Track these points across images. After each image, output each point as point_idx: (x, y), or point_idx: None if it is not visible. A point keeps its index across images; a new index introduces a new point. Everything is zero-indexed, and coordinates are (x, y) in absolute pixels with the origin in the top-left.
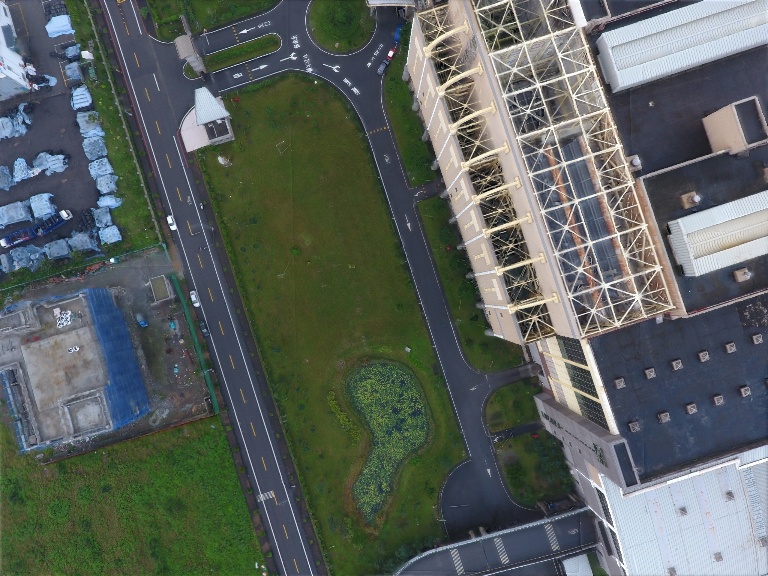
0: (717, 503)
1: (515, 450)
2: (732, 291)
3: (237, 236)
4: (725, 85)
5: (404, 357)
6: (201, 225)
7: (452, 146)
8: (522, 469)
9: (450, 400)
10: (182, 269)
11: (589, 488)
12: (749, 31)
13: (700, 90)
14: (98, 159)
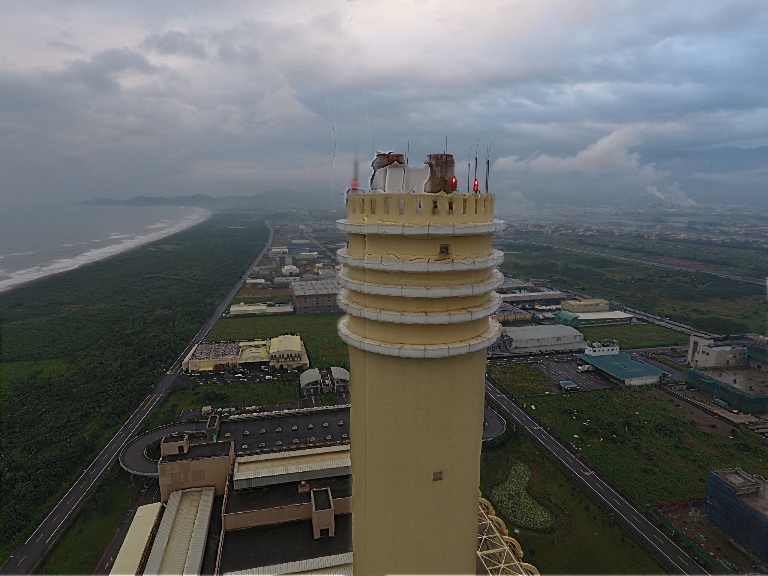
0: None
1: None
2: None
3: None
4: (308, 558)
5: None
6: None
7: None
8: None
9: None
10: None
11: None
12: (292, 570)
13: None
14: None
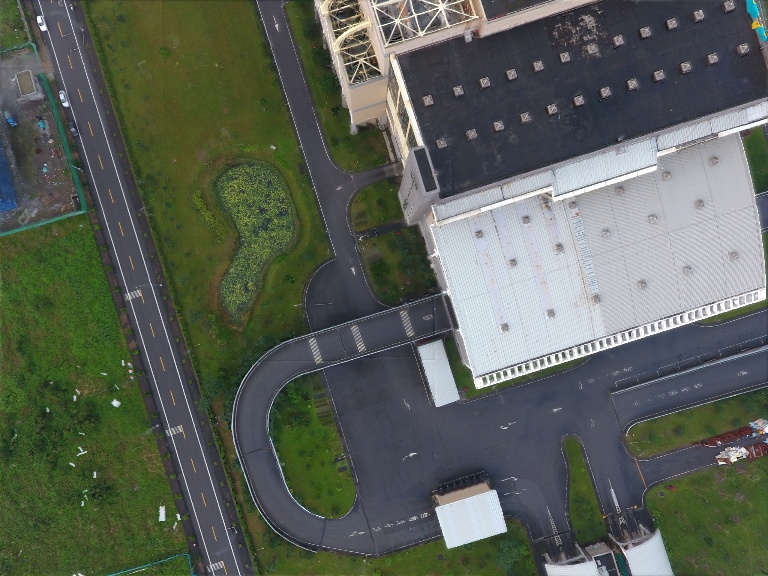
0: (548, 256)
1: (379, 248)
2: (535, 1)
3: (106, 36)
4: None
5: (271, 157)
6: (71, 27)
7: None
8: (385, 266)
9: (315, 199)
10: (52, 70)
11: (438, 266)
12: None
13: None
14: None
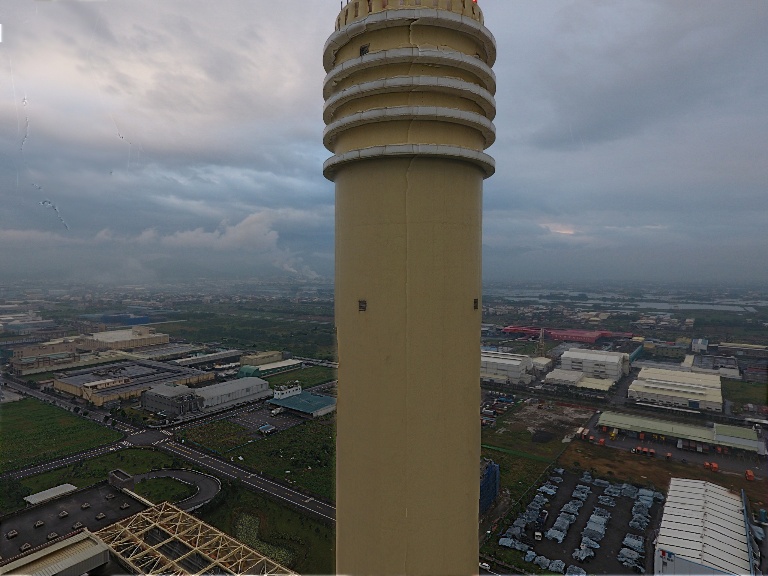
0: None
1: None
2: None
3: None
4: None
5: None
6: None
7: None
8: None
9: None
10: None
11: None
12: None
13: None
14: (564, 568)
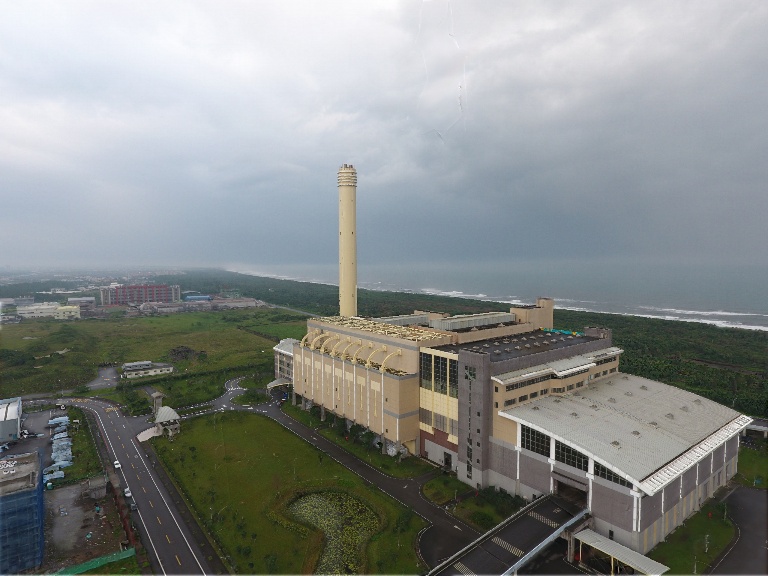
0: None
1: (469, 508)
2: None
3: (177, 459)
4: None
5: (335, 485)
6: (144, 463)
7: (325, 364)
8: None
9: None
10: (118, 483)
11: (528, 466)
12: None
13: None
14: None
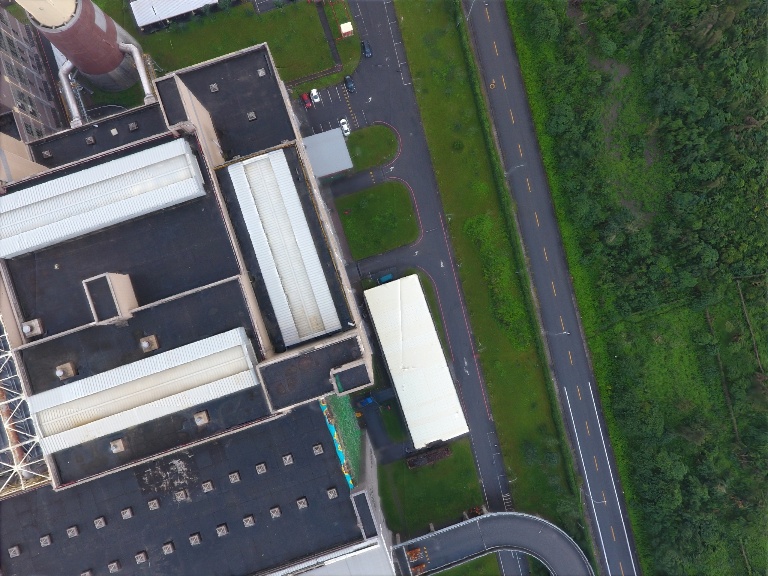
0: None
1: None
2: (111, 461)
3: None
4: (131, 247)
5: None
6: None
7: None
8: None
9: None
10: None
11: None
12: (126, 201)
13: (106, 252)
14: None
